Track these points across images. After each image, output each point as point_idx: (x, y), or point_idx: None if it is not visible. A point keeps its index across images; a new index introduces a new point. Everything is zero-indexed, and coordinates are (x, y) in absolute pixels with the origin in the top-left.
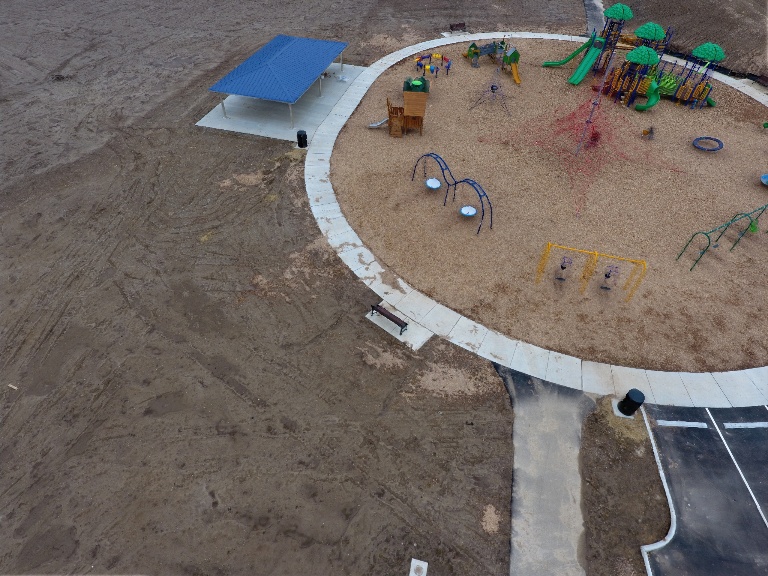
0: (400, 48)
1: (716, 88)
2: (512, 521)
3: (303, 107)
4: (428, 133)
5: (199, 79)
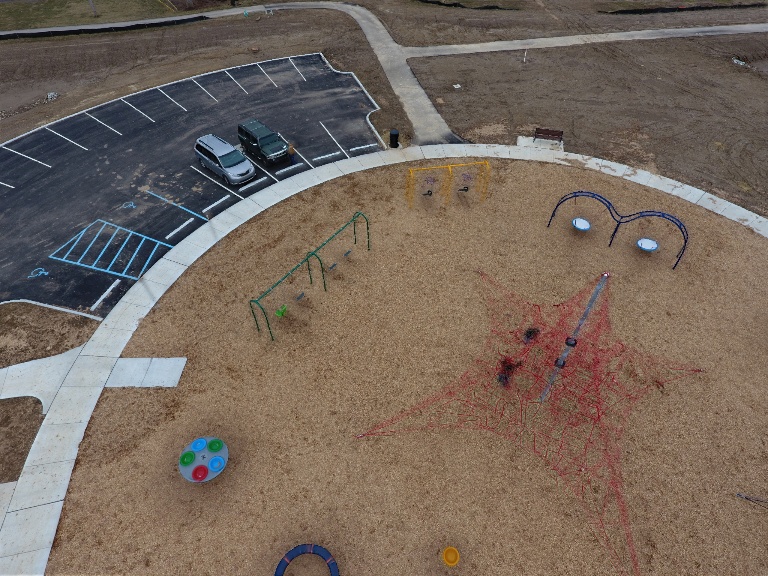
0: None
1: None
2: None
3: None
4: None
5: None
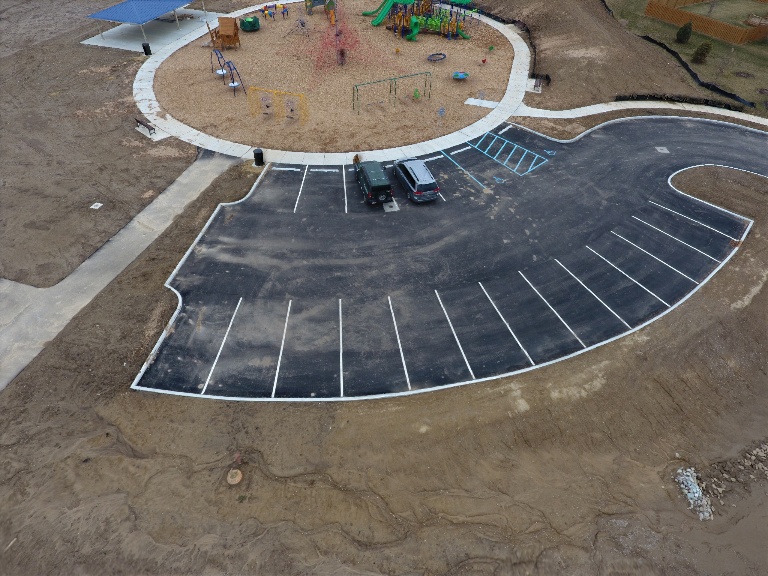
0: (261, 3)
1: (482, 29)
2: (159, 195)
3: (162, 35)
4: (243, 50)
5: (99, 20)
